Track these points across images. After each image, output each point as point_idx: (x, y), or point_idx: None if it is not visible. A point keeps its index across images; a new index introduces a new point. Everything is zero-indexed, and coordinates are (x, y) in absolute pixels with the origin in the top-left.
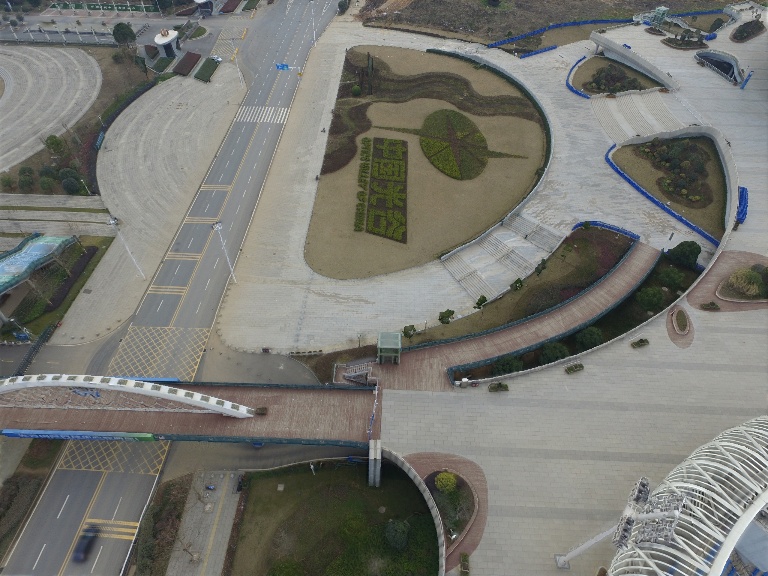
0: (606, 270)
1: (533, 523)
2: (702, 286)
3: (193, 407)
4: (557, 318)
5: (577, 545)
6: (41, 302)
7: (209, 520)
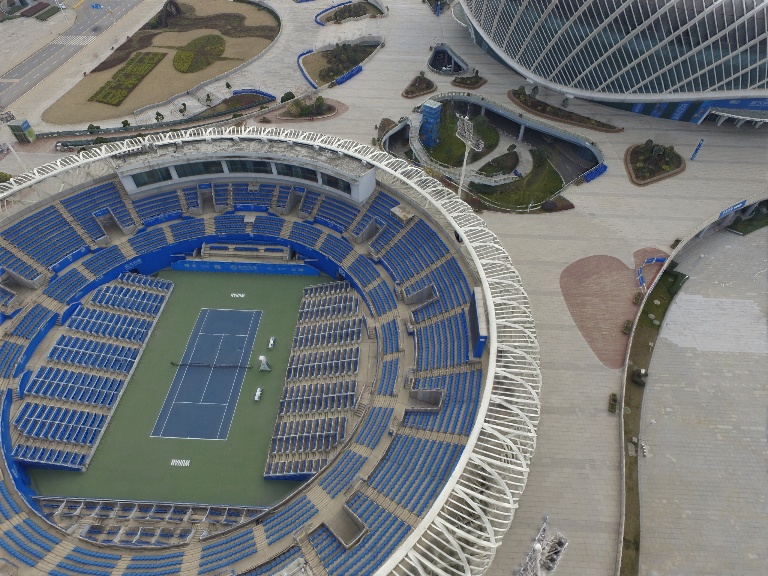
0: None
1: None
2: (272, 112)
3: None
4: (165, 129)
5: None
6: None
7: None
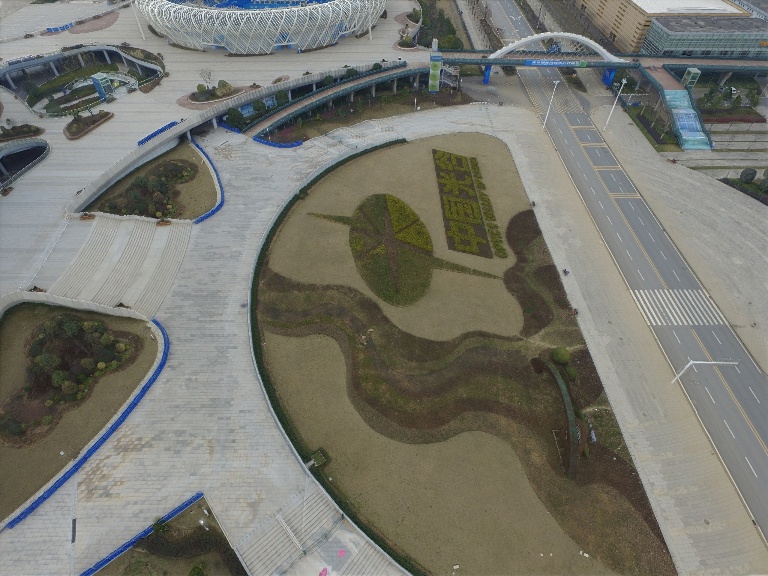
0: (292, 126)
1: (378, 43)
2: None
3: (512, 52)
4: None
5: (364, 41)
6: (649, 116)
7: None
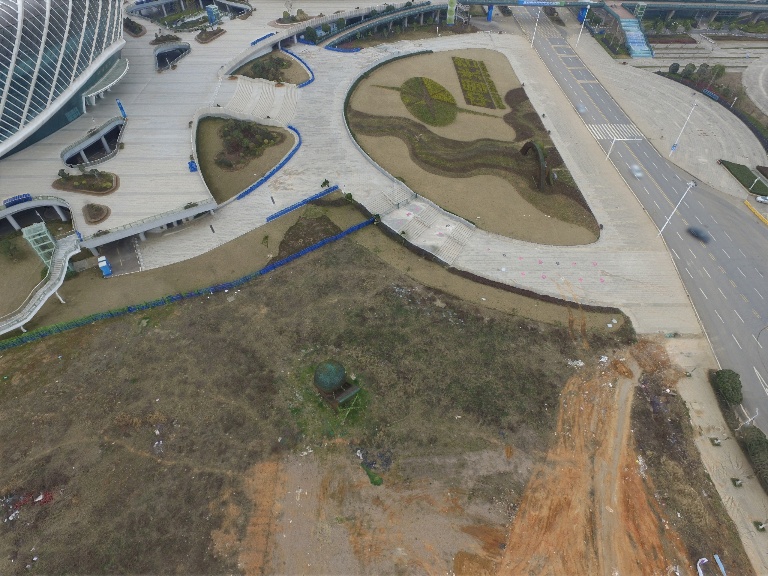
0: (350, 42)
1: None
2: None
3: None
4: None
5: None
6: None
7: (493, 12)
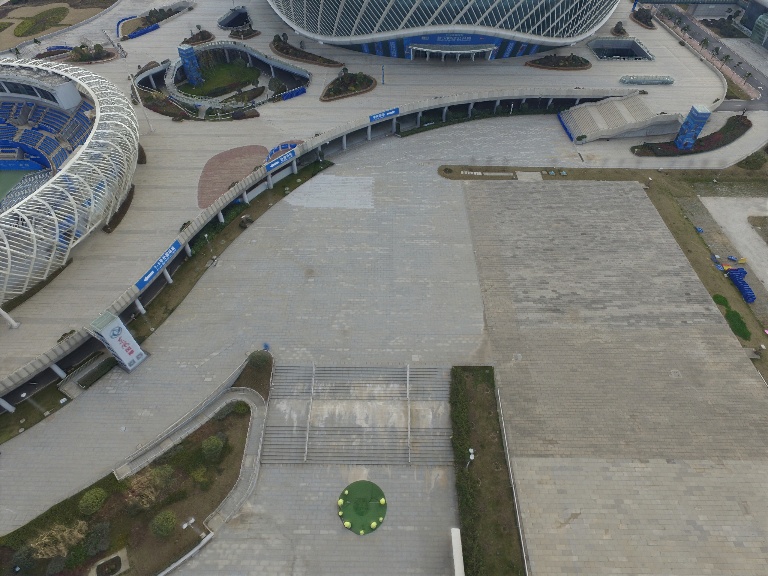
0: None
1: None
2: (60, 59)
3: None
4: None
5: None
6: None
7: None
